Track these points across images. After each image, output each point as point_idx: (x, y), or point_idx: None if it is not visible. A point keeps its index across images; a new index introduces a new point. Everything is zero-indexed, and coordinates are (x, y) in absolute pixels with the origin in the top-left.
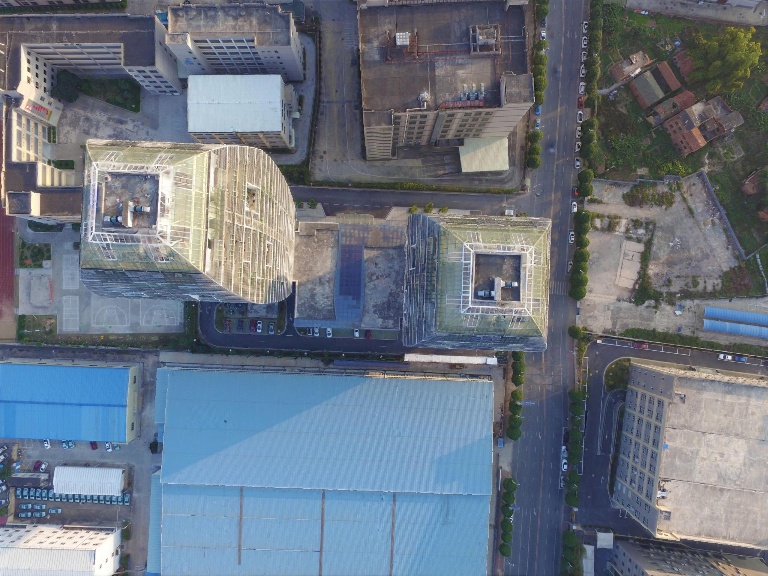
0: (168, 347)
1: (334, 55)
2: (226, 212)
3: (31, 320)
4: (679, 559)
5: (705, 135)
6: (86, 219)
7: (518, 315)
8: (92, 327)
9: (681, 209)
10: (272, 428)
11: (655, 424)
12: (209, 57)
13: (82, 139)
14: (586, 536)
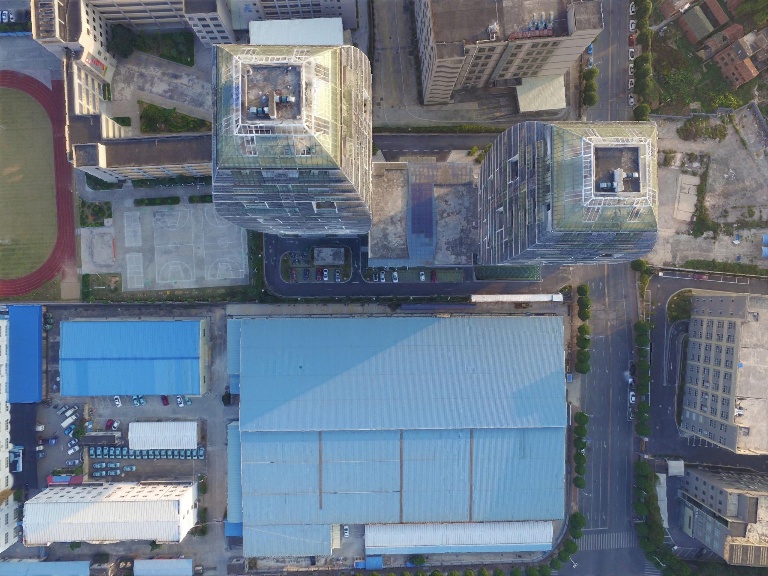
0: (236, 298)
1: (386, 2)
2: (353, 112)
3: (95, 279)
4: (751, 480)
5: (756, 66)
6: (228, 114)
7: (639, 206)
8: (157, 283)
9: (734, 141)
10: (347, 371)
11: (727, 346)
12: (266, 5)
13: (137, 95)
14: (656, 466)
